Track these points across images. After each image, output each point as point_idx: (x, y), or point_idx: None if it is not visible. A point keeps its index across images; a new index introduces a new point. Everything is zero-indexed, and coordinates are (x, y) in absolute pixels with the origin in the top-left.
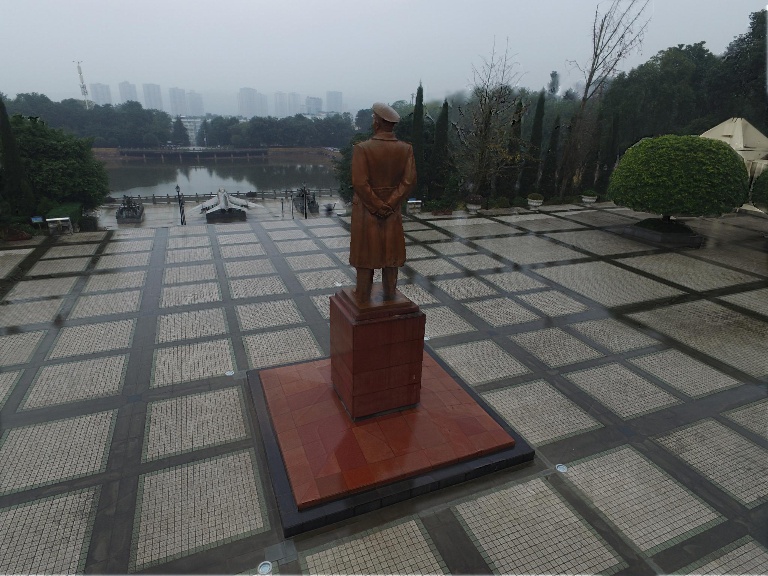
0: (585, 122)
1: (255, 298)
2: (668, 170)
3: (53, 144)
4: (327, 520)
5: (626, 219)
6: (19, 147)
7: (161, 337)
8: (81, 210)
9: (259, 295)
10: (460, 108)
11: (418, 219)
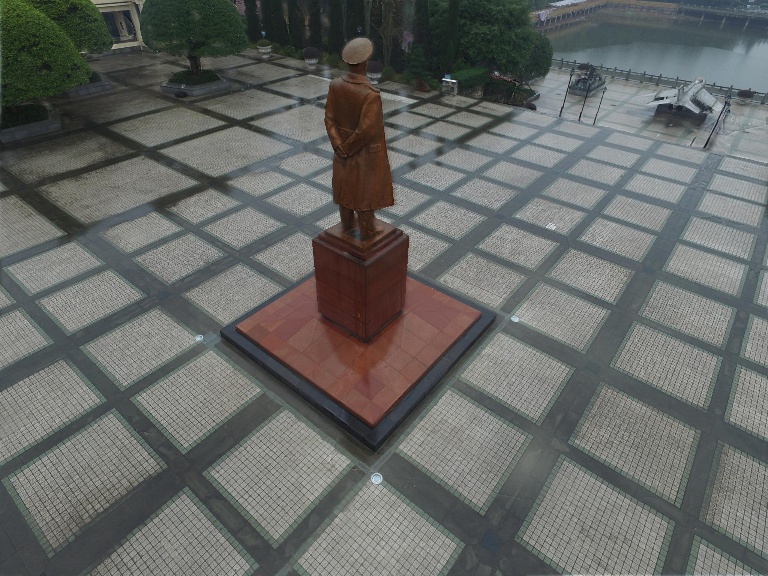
0: None
1: (464, 201)
2: None
3: (490, 9)
4: None
5: None
6: (465, 9)
7: None
8: (485, 75)
9: (471, 200)
10: None
11: None
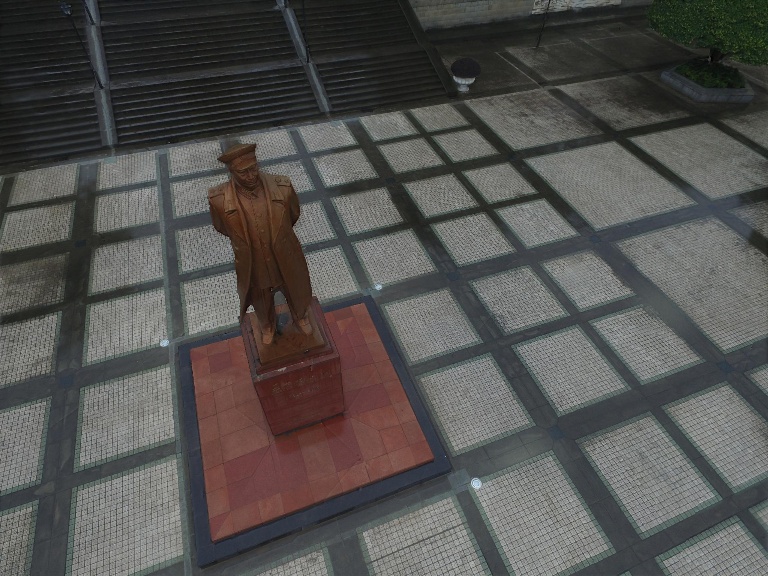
0: None
1: None
2: None
3: None
4: None
5: None
6: None
7: None
8: None
9: None
10: None
11: None
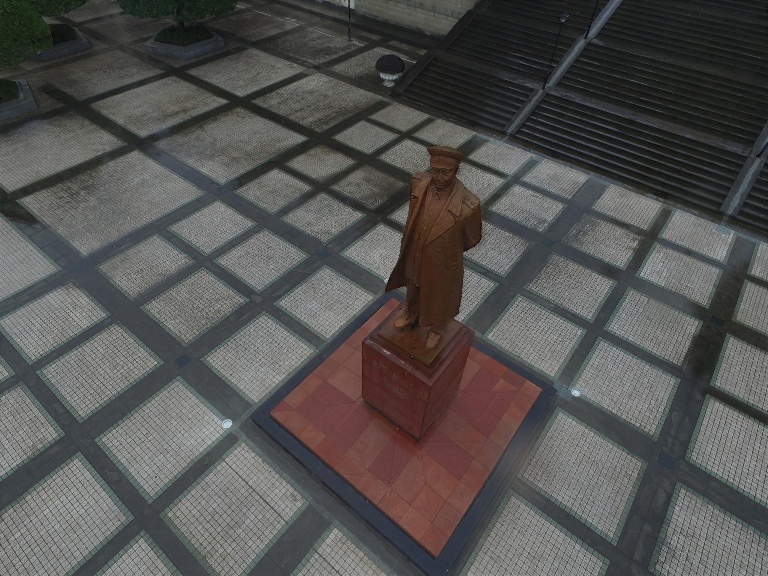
0: None
1: None
2: None
3: None
4: None
5: None
6: None
7: None
8: None
9: None
10: None
11: None
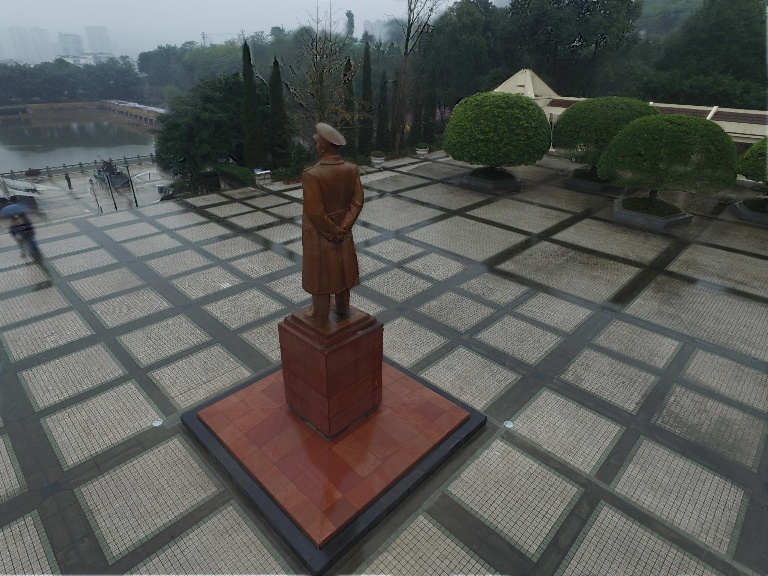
0: (409, 77)
1: (136, 322)
2: (494, 126)
3: None
4: (349, 547)
5: (458, 169)
6: None
7: (39, 401)
8: None
9: (139, 317)
10: (291, 66)
11: (272, 191)
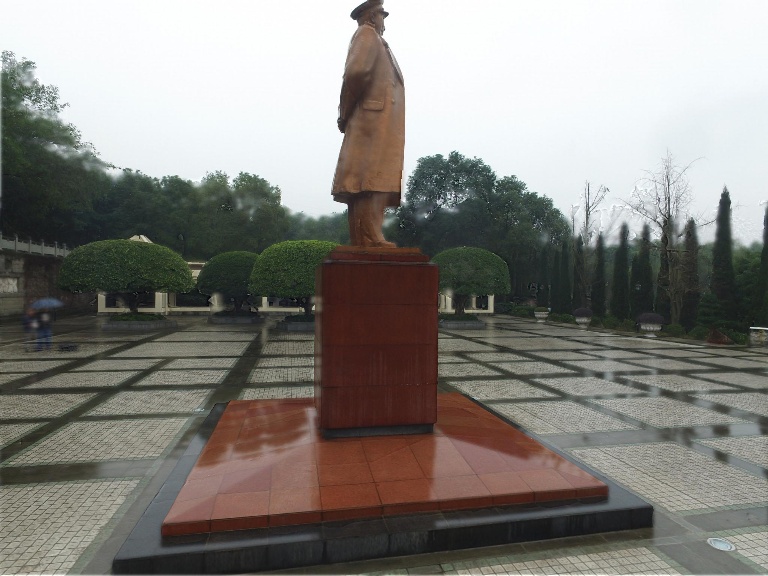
0: None
1: (711, 403)
2: None
3: None
4: None
5: None
6: None
7: (543, 379)
8: None
9: (728, 405)
10: None
11: None
